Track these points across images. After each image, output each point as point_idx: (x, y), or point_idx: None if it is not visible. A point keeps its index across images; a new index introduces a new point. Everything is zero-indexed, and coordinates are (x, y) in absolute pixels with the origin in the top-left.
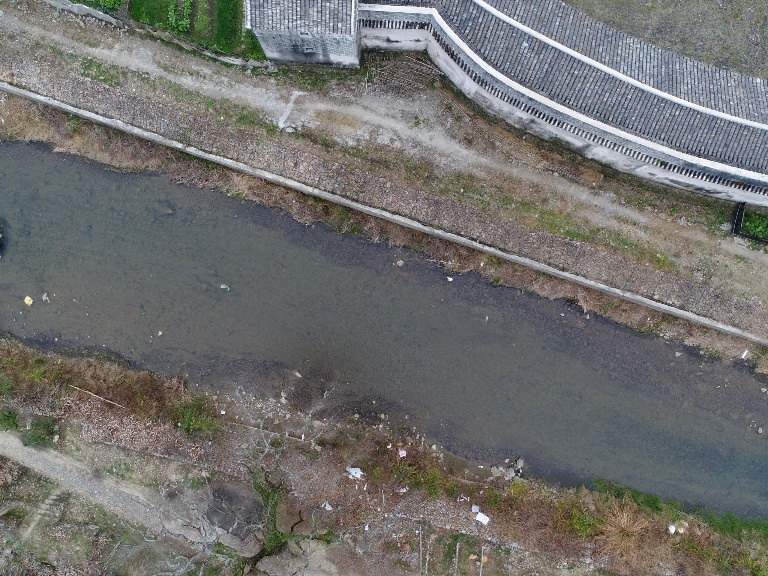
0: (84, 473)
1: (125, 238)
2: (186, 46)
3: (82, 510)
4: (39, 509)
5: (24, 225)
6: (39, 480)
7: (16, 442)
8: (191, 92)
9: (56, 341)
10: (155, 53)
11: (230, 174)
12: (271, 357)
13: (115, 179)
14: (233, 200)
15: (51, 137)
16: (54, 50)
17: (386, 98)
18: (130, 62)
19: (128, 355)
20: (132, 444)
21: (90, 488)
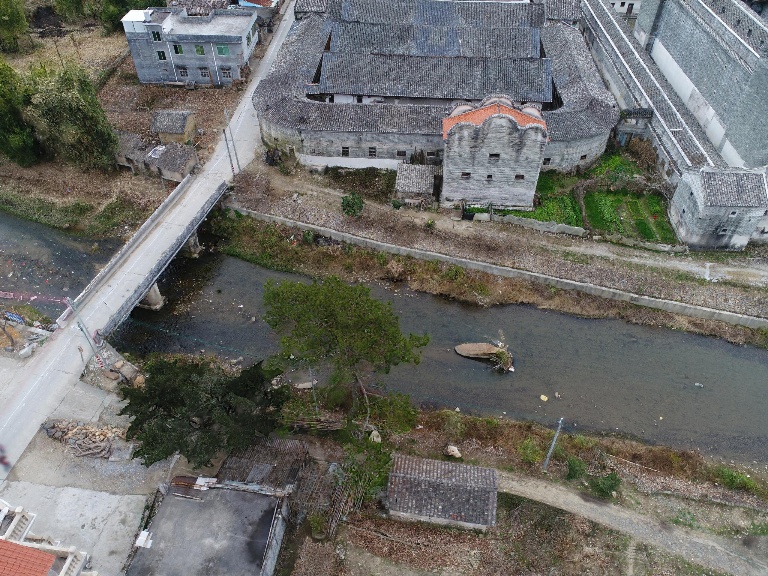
0: (651, 525)
1: (606, 357)
2: (630, 243)
3: (665, 560)
4: (627, 554)
5: (526, 350)
6: (611, 532)
7: (577, 499)
8: (639, 265)
9: (575, 426)
10: (609, 248)
11: (672, 315)
12: (762, 434)
13: (585, 323)
14: (677, 332)
15: (535, 300)
16: (542, 249)
17: (767, 265)
18: (594, 252)
19: (640, 435)
20: (690, 493)
21: (663, 539)
